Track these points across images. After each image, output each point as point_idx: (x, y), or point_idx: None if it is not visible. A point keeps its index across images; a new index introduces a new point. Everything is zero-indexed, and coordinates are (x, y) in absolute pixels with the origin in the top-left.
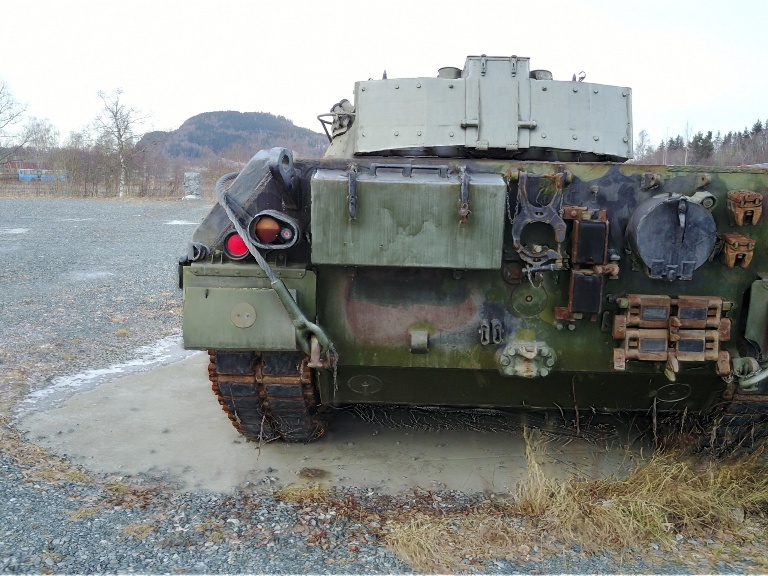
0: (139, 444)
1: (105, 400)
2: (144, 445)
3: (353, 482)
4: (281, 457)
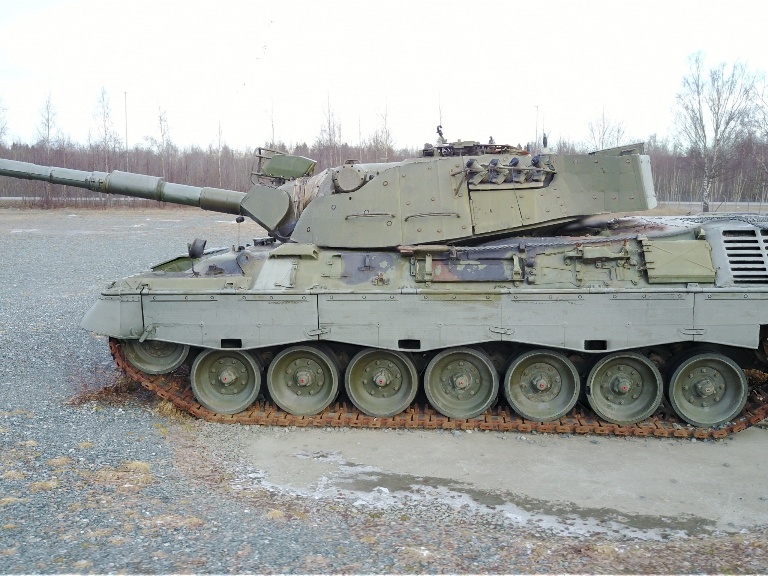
0: (766, 472)
1: (651, 496)
2: (766, 470)
3: (767, 418)
4: (743, 433)
